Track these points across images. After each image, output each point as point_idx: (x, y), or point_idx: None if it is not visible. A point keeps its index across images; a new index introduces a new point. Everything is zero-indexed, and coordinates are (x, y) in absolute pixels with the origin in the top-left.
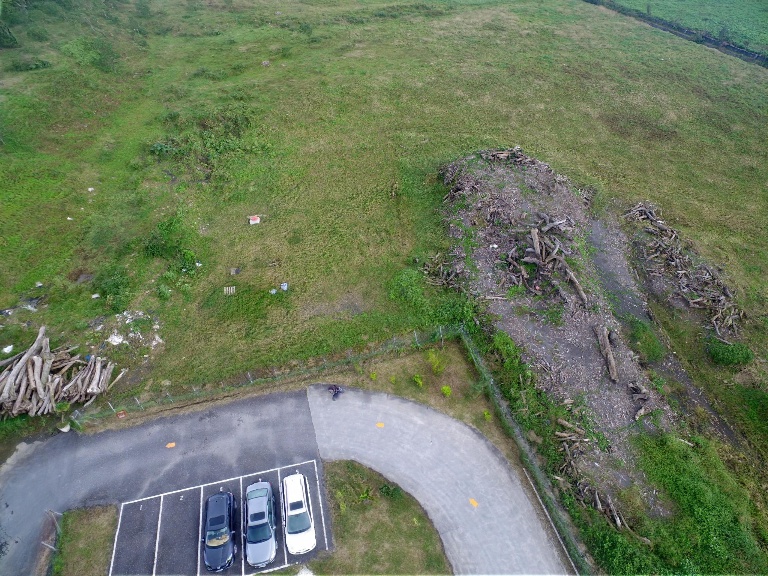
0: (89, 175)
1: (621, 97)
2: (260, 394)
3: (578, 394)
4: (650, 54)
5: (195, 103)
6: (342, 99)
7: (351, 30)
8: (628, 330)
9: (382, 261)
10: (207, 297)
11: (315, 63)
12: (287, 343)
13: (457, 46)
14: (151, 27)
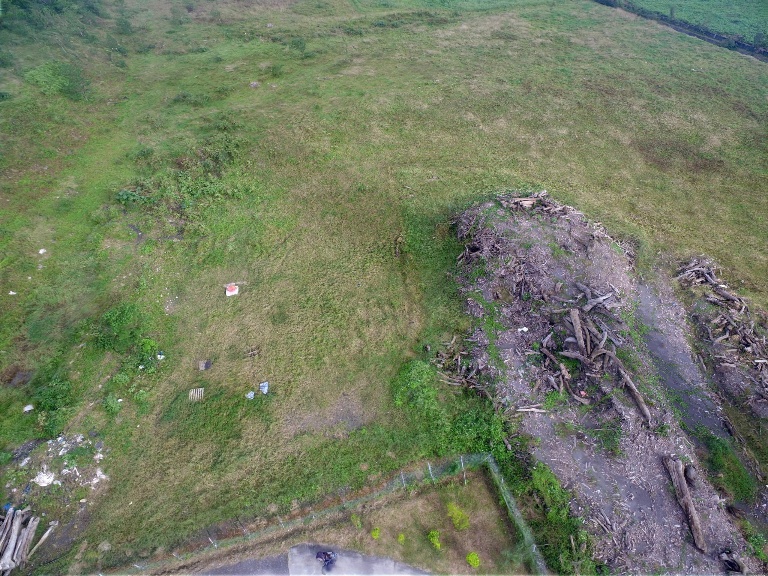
0: (42, 232)
1: (653, 118)
2: (226, 564)
3: (653, 571)
4: (679, 64)
5: (172, 136)
6: (338, 126)
7: (348, 43)
8: (704, 453)
9: (385, 348)
10: (168, 405)
11: (309, 83)
12: (264, 478)
13: (464, 59)
14: (132, 44)
